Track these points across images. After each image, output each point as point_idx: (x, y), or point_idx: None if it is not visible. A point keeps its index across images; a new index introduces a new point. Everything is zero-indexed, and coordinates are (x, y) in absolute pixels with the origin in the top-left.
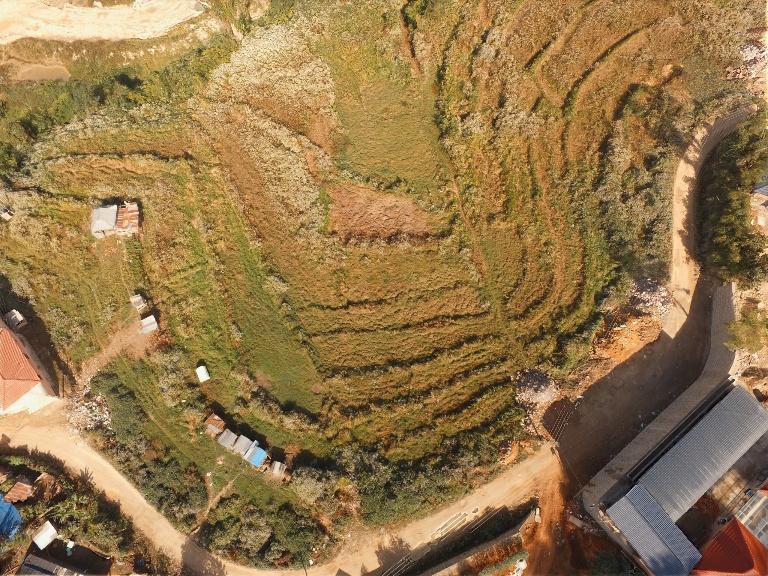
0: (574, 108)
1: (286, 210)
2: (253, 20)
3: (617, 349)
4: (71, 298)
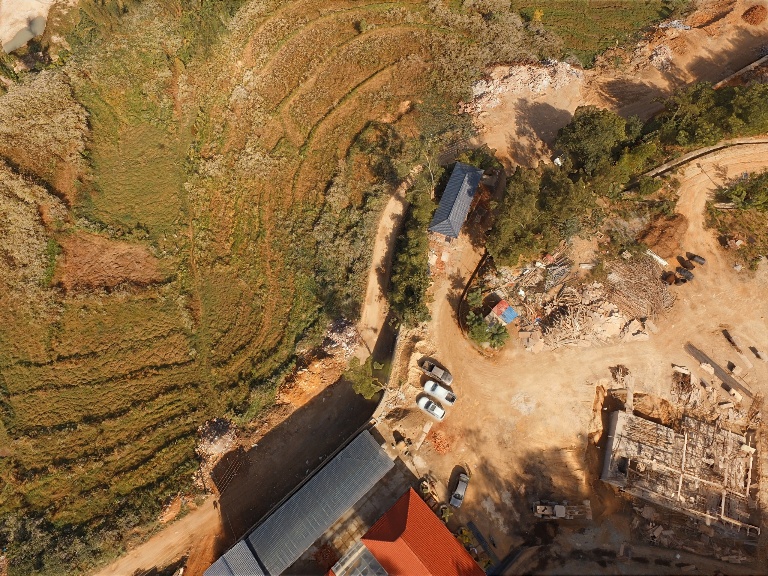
0: (308, 147)
1: (7, 264)
2: (53, 62)
3: (296, 394)
4: None
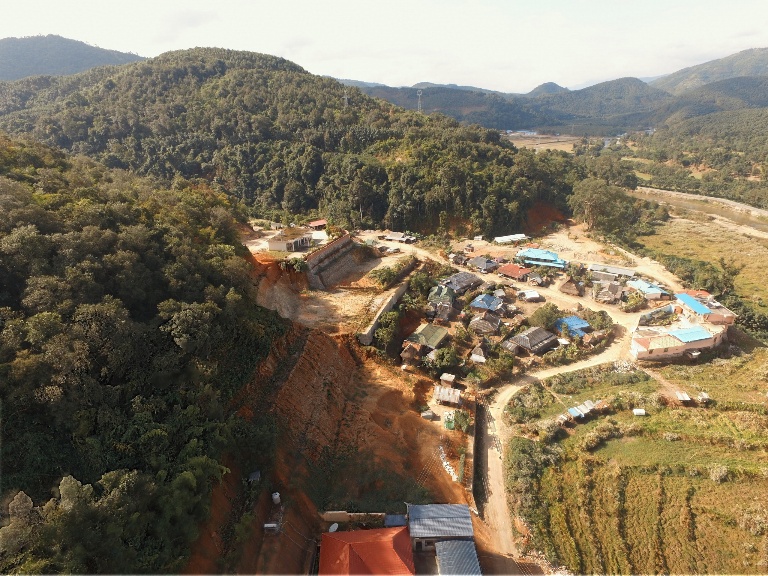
0: None
1: None
2: None
3: None
4: (710, 376)
